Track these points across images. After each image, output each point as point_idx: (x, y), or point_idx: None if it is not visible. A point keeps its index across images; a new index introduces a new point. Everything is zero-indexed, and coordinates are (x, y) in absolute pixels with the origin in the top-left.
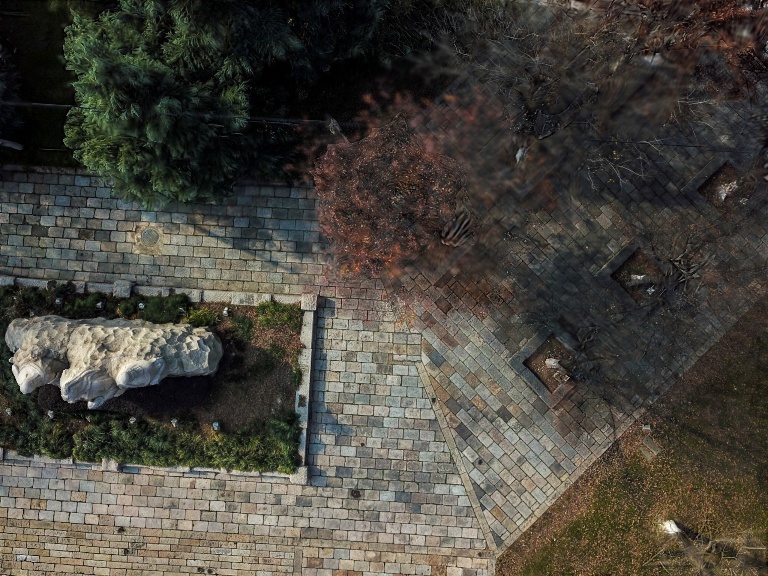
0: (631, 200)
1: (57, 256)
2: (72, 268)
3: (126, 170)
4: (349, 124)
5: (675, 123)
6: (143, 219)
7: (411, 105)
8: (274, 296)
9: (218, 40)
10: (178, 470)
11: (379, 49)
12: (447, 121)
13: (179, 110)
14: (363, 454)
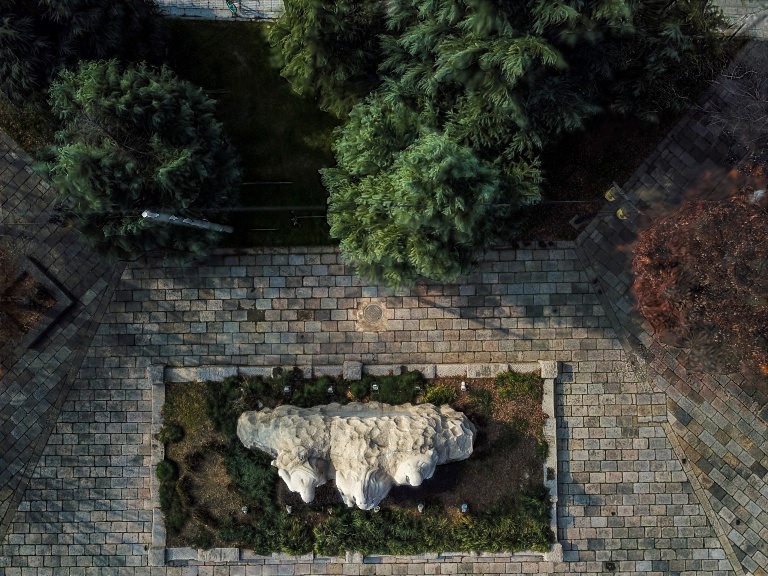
0: None
1: (276, 340)
2: (293, 352)
3: None
4: (571, 179)
5: None
6: (364, 295)
7: (633, 155)
8: (511, 366)
9: (523, 119)
10: (426, 557)
11: (636, 106)
12: (672, 168)
13: (493, 198)
14: (615, 524)
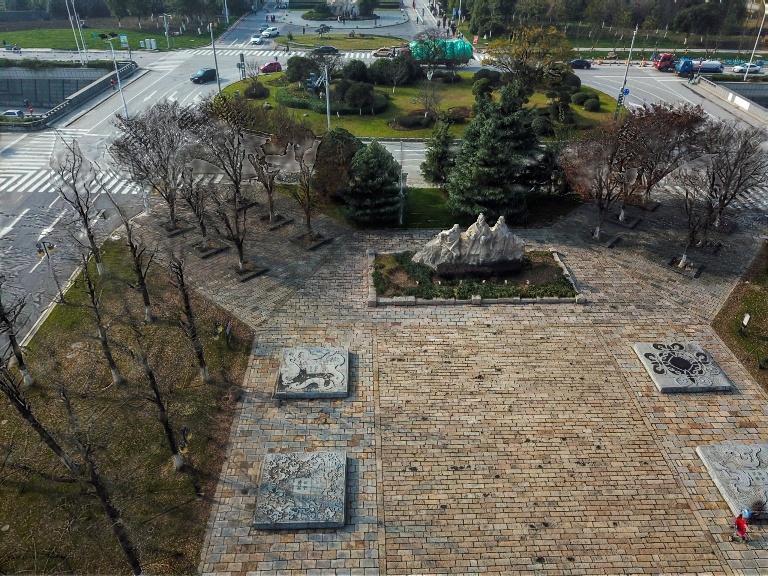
0: None
1: None
2: None
3: (488, 171)
4: None
5: None
6: None
7: None
8: None
9: (514, 144)
10: (514, 299)
11: None
12: None
13: None
14: None
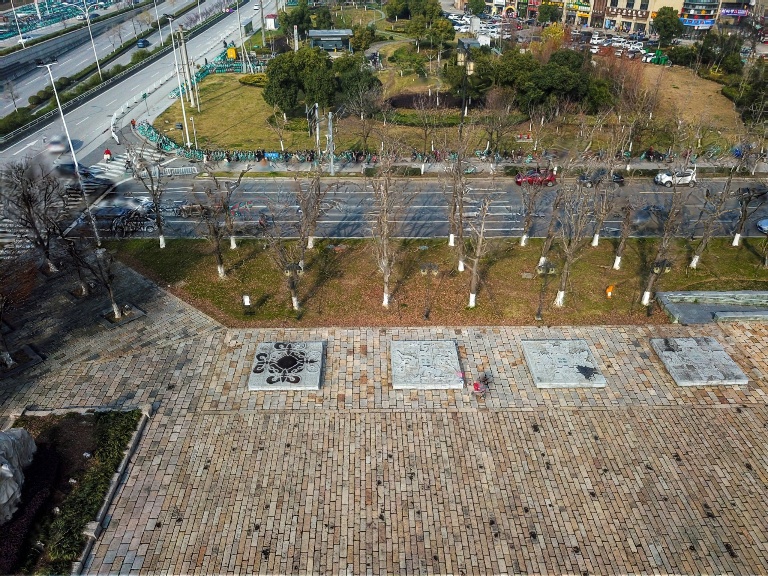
0: (40, 297)
1: None
2: None
3: None
4: None
5: (6, 286)
6: None
7: None
8: None
9: None
10: (115, 480)
11: None
12: None
13: None
14: (144, 385)
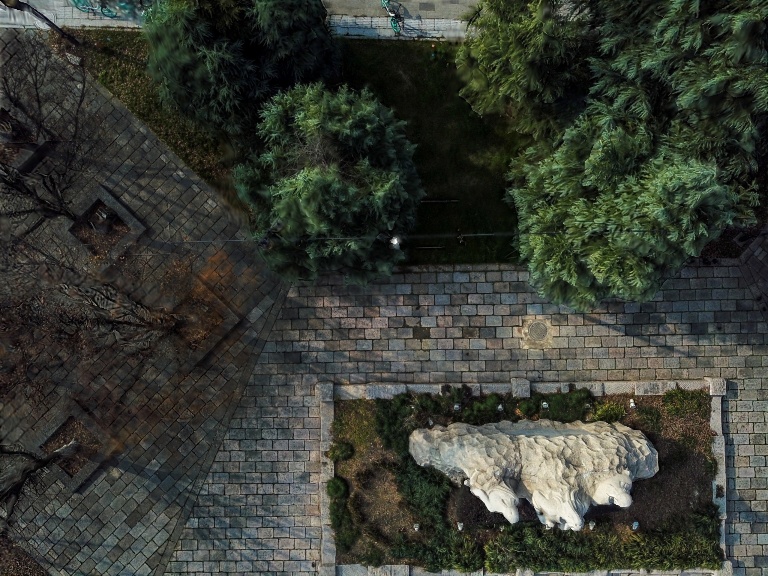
0: None
1: (442, 358)
2: (458, 369)
3: None
4: None
5: None
6: (529, 312)
7: None
8: (678, 383)
9: (753, 144)
10: (596, 574)
11: None
12: None
13: None
14: None
